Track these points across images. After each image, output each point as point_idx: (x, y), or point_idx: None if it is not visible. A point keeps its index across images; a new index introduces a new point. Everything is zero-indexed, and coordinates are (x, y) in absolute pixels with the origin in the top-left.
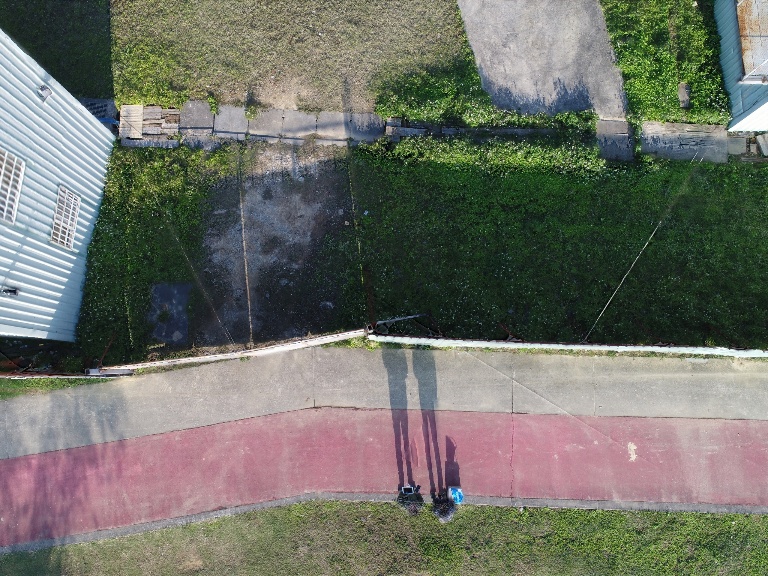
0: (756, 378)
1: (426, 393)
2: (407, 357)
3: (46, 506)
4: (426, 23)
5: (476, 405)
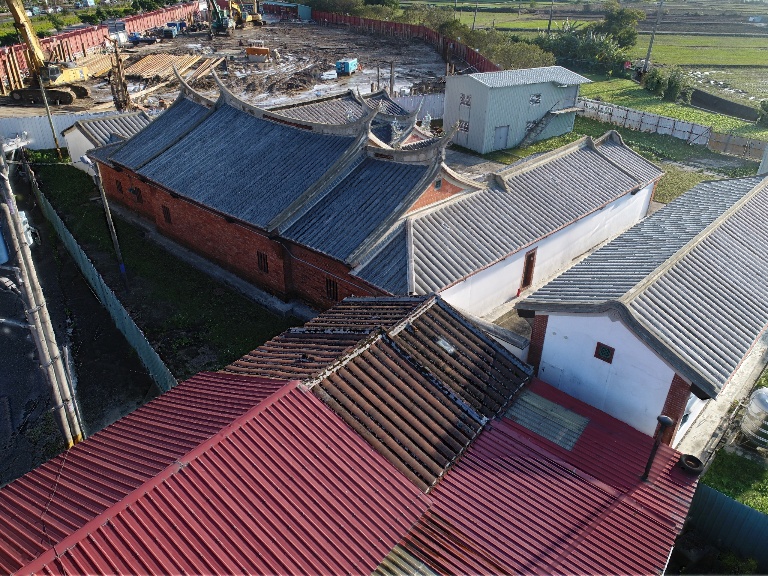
0: None
1: None
2: None
3: None
4: None
5: None
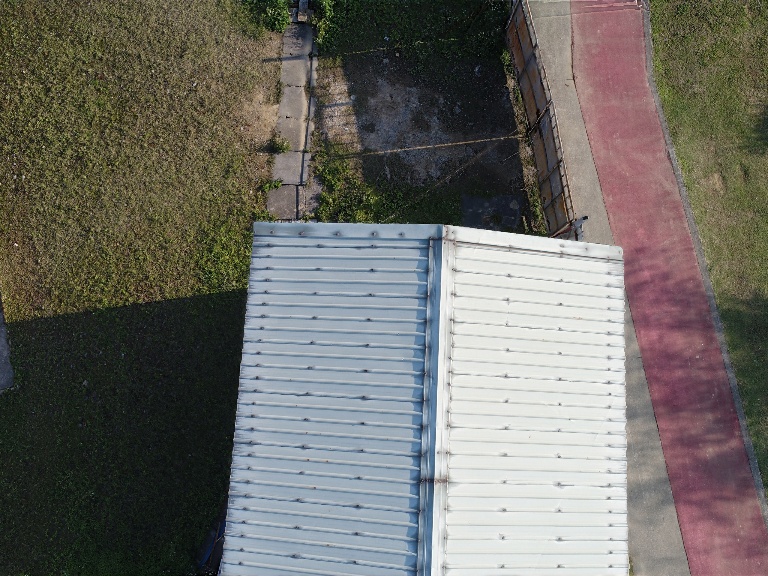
0: None
1: None
2: None
3: (682, 316)
4: None
5: None
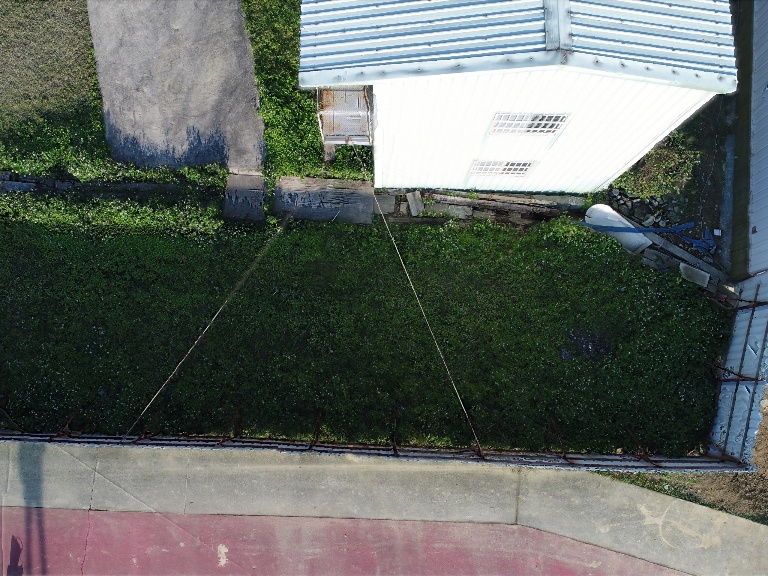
0: (372, 471)
1: None
2: None
3: None
4: (53, 63)
5: (50, 500)
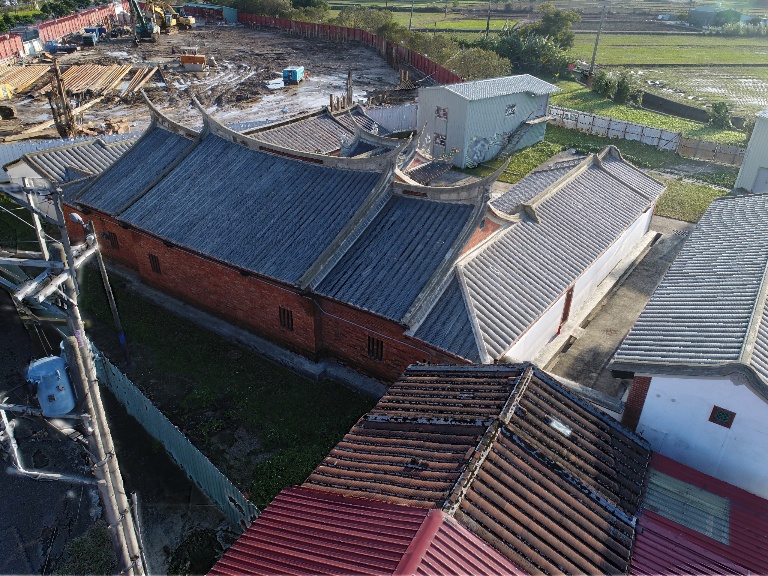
0: None
1: None
2: None
3: None
4: None
5: None
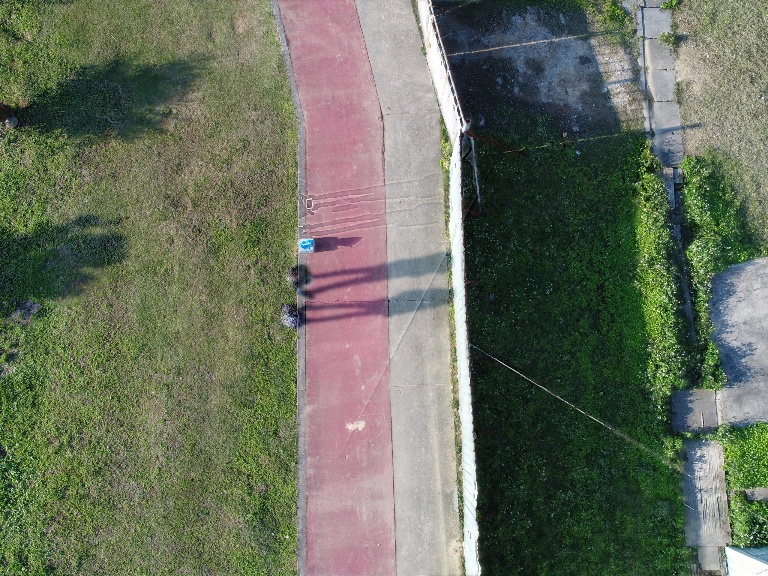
0: (442, 567)
1: (402, 216)
2: (436, 197)
3: None
4: None
5: (394, 265)
